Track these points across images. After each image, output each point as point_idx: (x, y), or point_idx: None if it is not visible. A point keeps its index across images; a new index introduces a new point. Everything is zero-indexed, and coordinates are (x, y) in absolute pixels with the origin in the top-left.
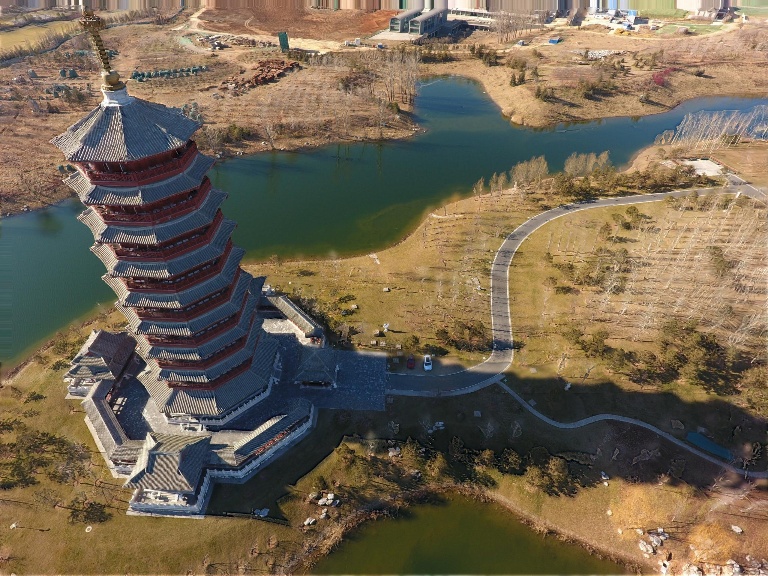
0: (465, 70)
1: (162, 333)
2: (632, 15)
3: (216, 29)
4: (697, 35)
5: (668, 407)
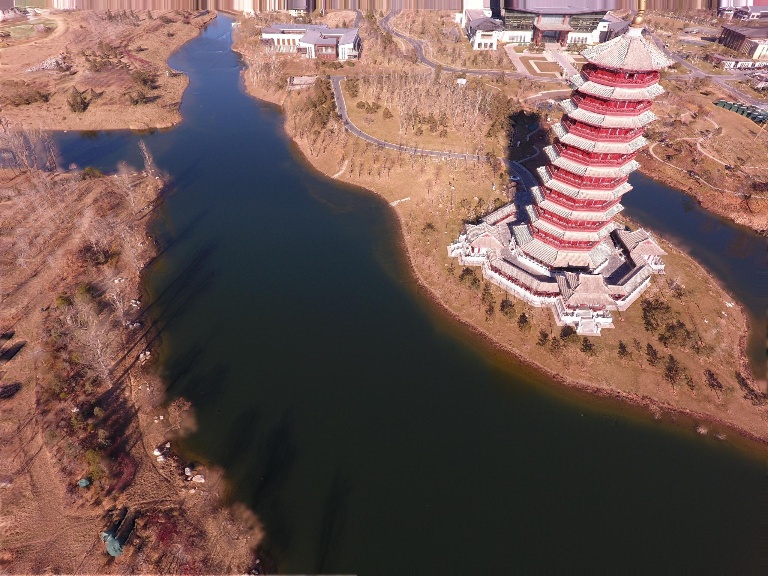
0: None
1: None
2: None
3: None
4: (56, 28)
5: None
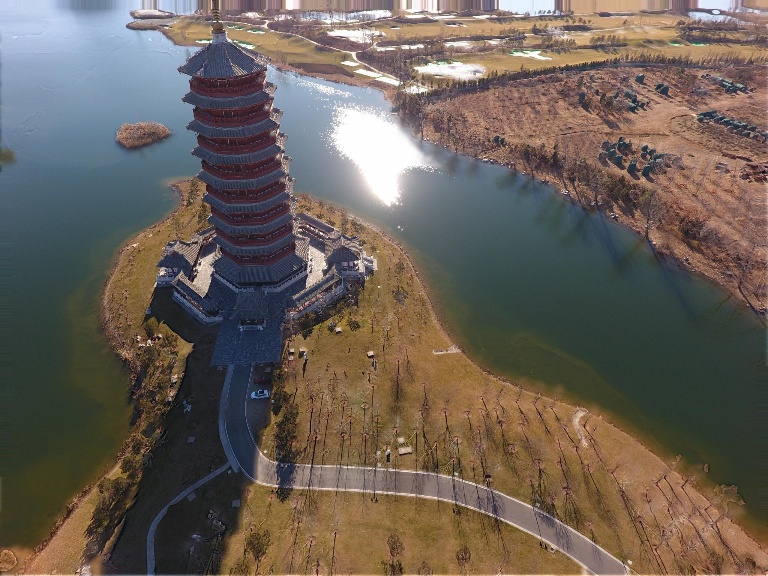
0: None
1: None
2: None
3: None
4: None
5: None
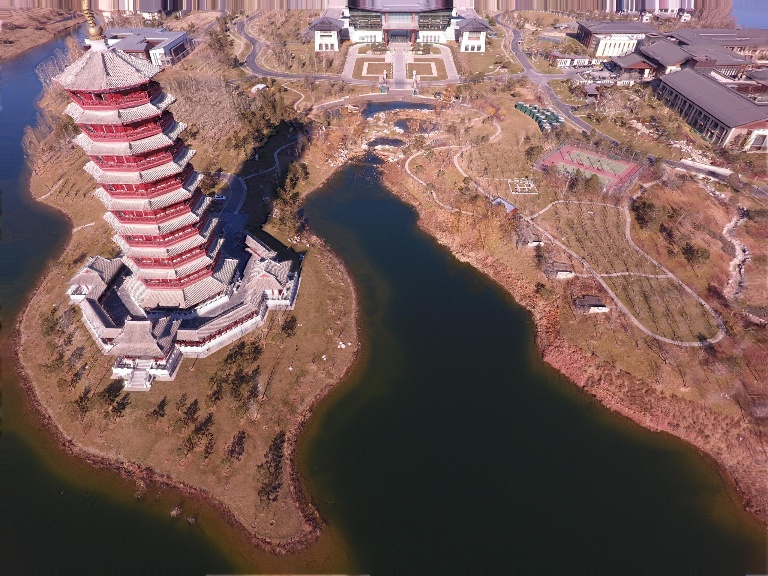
0: None
1: None
2: None
3: None
4: None
5: (276, 139)
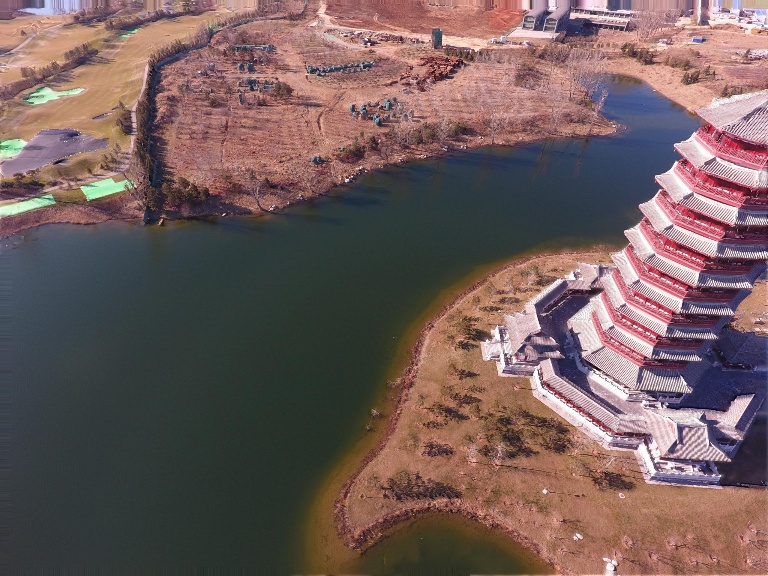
0: (620, 68)
1: (703, 313)
2: (763, 15)
3: (351, 25)
4: None
5: None
